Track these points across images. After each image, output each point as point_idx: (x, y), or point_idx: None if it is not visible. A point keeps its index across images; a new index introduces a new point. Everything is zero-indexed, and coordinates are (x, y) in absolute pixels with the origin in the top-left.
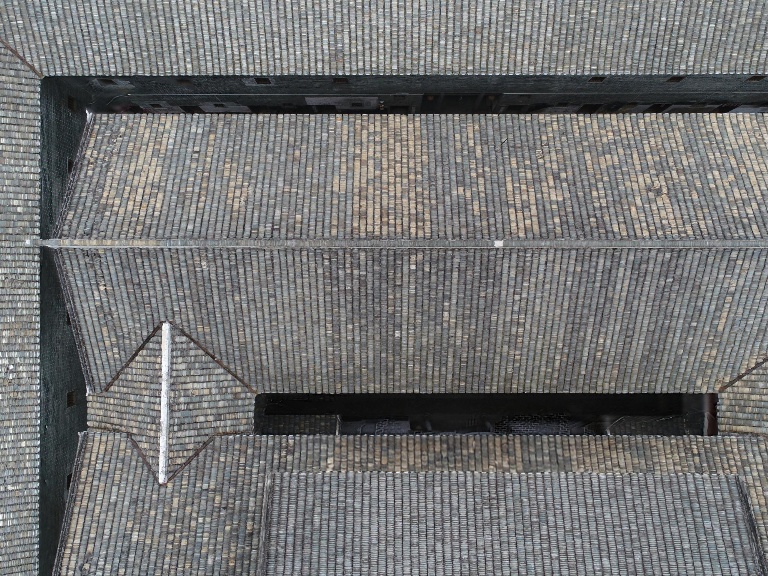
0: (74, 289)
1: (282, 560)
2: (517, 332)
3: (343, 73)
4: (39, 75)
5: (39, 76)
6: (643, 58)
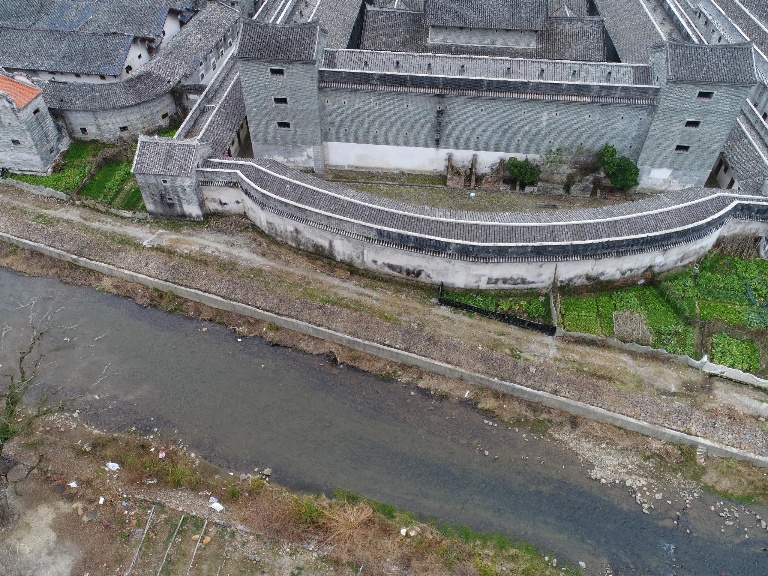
0: None
1: None
2: None
3: None
4: None
5: None
6: None
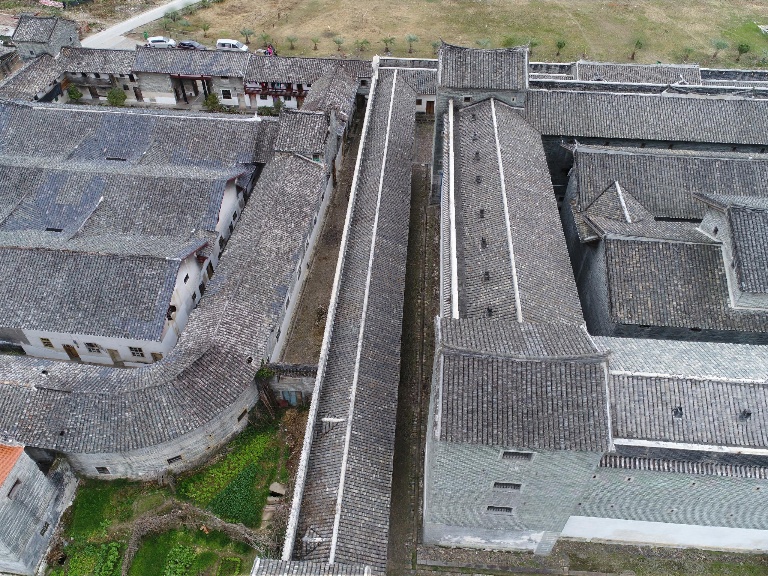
0: (579, 167)
1: None
2: (767, 194)
3: (658, 139)
4: (540, 134)
5: (540, 134)
6: None
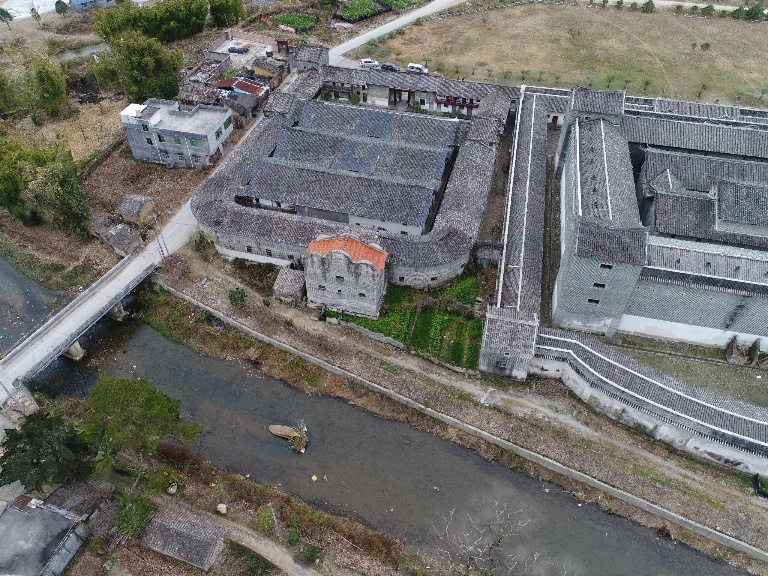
0: (648, 160)
1: None
2: None
3: (698, 149)
4: (628, 141)
5: (628, 141)
6: (767, 155)
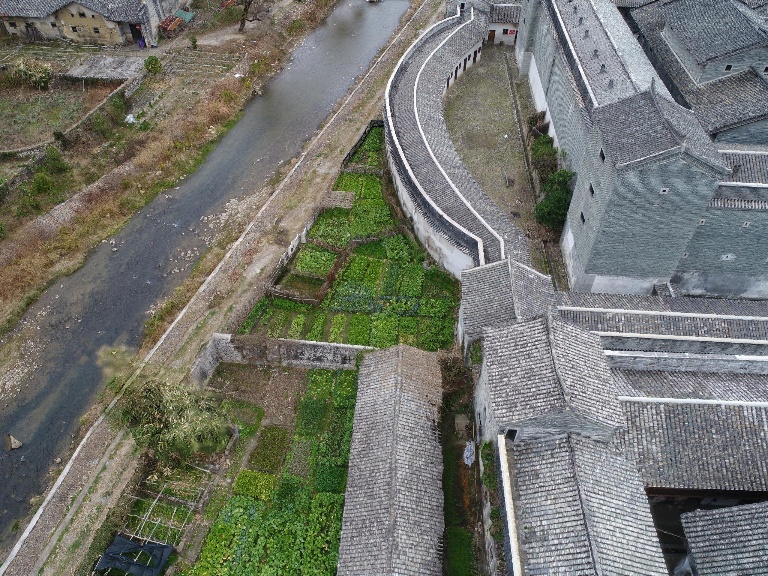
0: None
1: (737, 1)
2: None
3: None
4: None
5: None
6: None
